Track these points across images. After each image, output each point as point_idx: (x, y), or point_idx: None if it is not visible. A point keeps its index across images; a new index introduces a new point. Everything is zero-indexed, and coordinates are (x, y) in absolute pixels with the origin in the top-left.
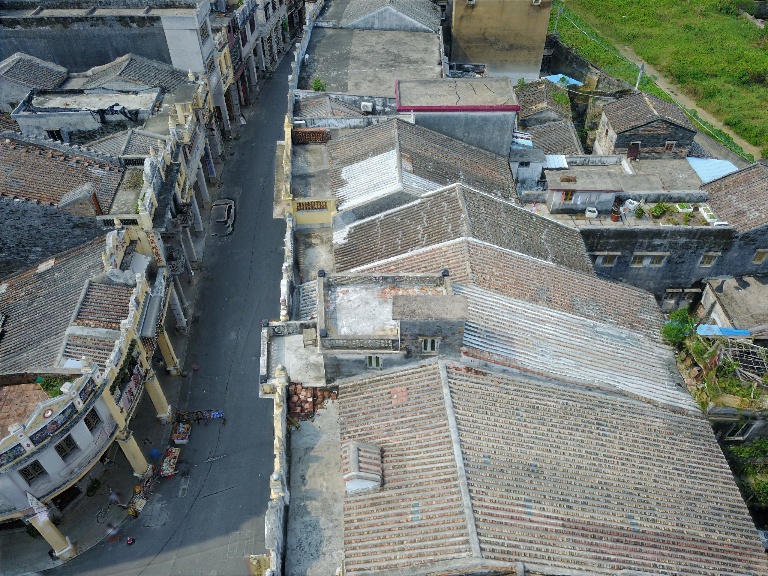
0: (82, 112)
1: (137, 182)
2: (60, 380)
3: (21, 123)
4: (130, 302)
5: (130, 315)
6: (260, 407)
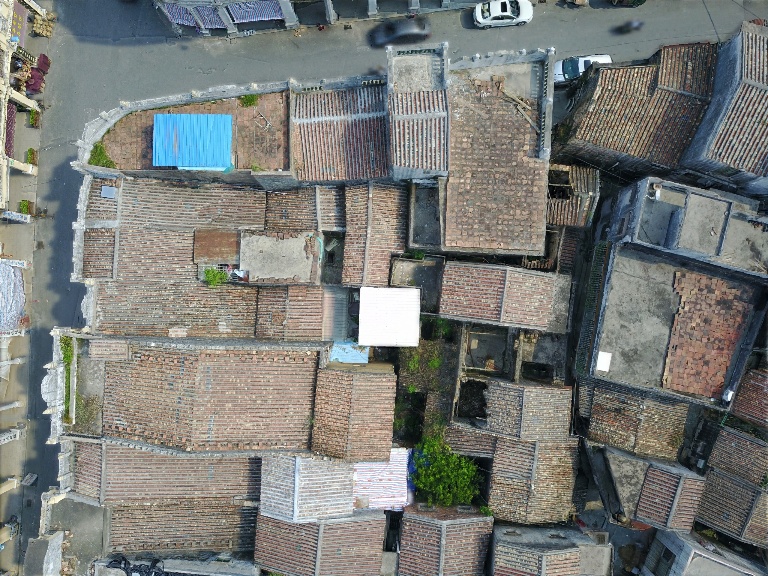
0: (173, 570)
1: (86, 406)
2: (99, 164)
3: (249, 572)
4: (74, 244)
5: (77, 237)
6: (64, 240)
